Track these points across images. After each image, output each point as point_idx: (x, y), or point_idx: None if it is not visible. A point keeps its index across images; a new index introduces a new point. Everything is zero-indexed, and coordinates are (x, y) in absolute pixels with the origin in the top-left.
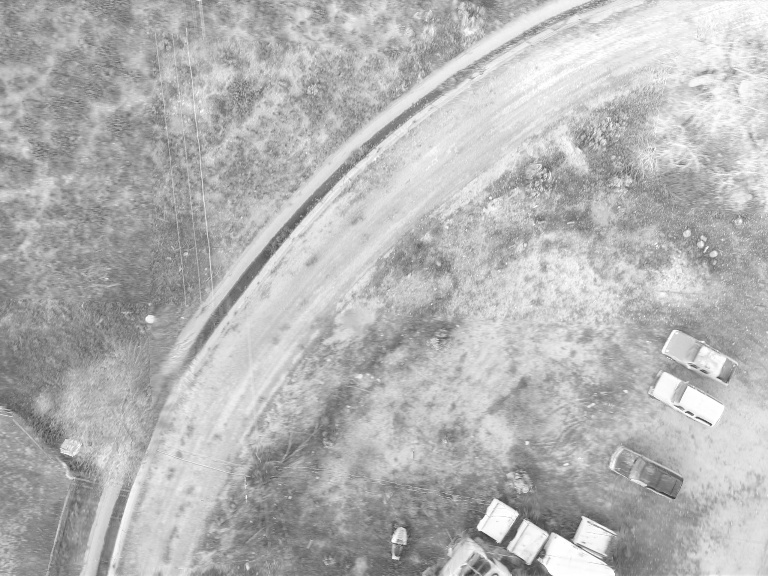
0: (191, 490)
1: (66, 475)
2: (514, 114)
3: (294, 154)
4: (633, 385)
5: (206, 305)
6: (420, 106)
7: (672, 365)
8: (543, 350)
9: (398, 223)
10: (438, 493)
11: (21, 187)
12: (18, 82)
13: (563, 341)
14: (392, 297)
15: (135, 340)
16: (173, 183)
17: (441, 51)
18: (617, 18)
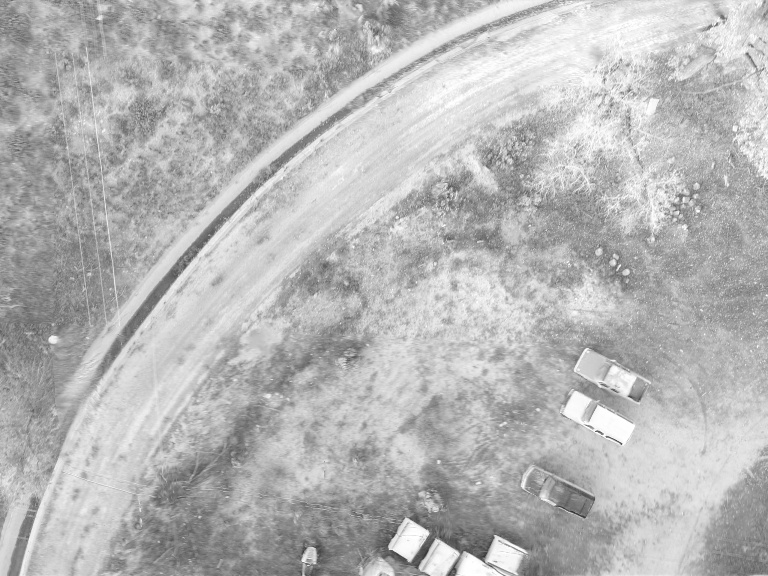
0: (96, 511)
1: None
2: (421, 133)
3: (199, 174)
4: (546, 404)
5: (112, 325)
6: (329, 124)
7: (585, 383)
8: (455, 369)
9: (304, 243)
10: (349, 512)
11: None
12: None
13: (475, 360)
14: (299, 317)
15: (38, 361)
16: (75, 203)
17: (348, 69)
18: (525, 36)
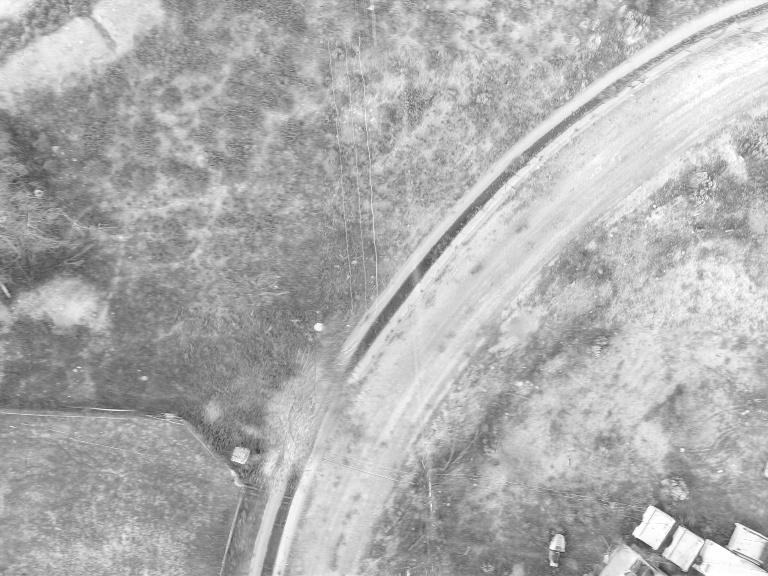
0: (358, 497)
1: (234, 482)
2: (677, 122)
3: (460, 162)
4: None
5: (370, 313)
6: (579, 114)
7: None
8: (698, 357)
9: (562, 231)
10: (594, 500)
11: (195, 195)
12: (194, 91)
13: (718, 348)
14: (555, 305)
15: (303, 348)
16: (343, 191)
17: (604, 60)
18: None
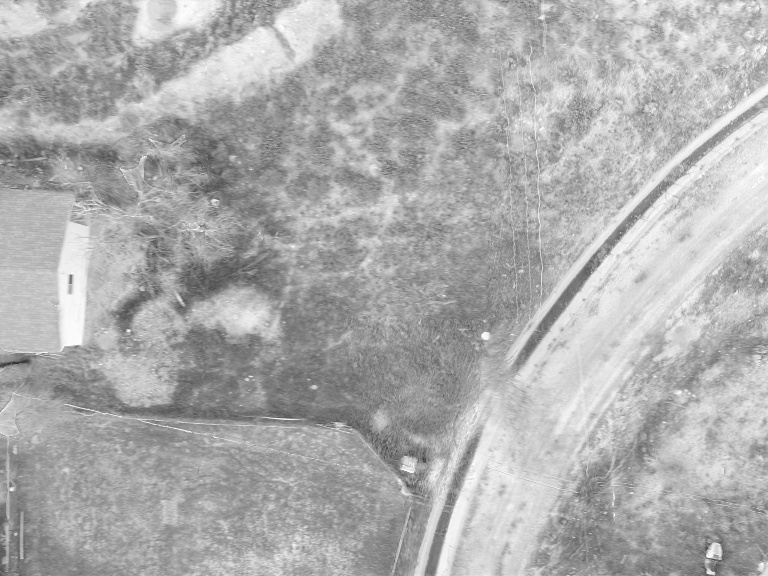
0: (523, 506)
1: (401, 491)
2: None
3: (626, 172)
4: None
5: (532, 322)
6: (737, 123)
7: None
8: None
9: (725, 240)
10: (749, 508)
11: (366, 205)
12: (369, 100)
13: None
14: (718, 314)
15: (470, 357)
16: (511, 201)
17: (766, 69)
18: None
